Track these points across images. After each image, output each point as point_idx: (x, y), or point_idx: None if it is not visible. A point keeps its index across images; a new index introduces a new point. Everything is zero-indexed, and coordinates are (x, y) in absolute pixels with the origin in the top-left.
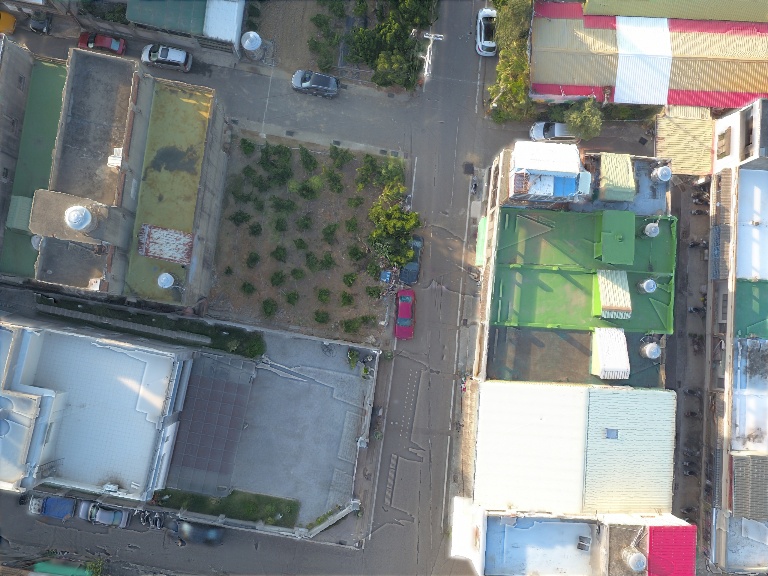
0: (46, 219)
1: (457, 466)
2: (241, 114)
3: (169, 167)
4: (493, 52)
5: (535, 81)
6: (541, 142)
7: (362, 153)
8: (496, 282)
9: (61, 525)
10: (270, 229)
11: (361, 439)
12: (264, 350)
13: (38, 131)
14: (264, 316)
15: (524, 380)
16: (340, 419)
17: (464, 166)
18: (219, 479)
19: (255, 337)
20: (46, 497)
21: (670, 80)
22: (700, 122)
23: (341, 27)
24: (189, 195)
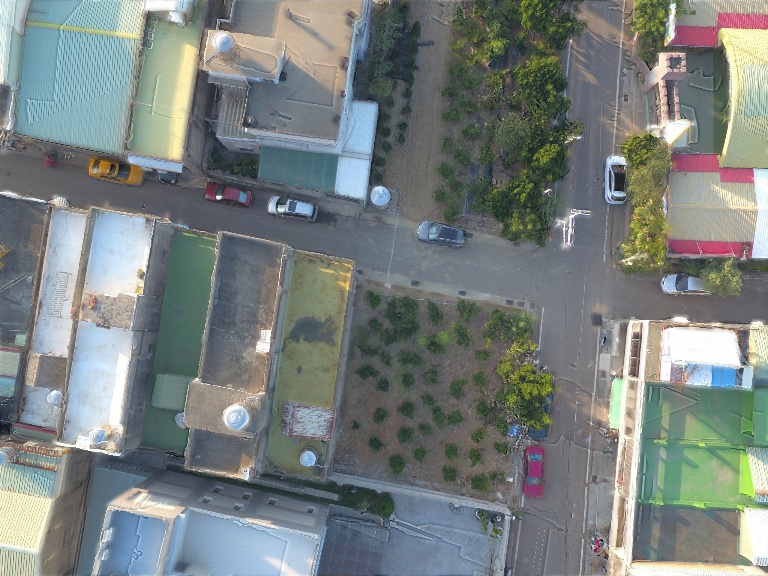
0: (200, 412)
1: None
2: (366, 264)
3: (308, 338)
4: (623, 201)
5: (670, 237)
6: (697, 328)
7: (488, 303)
8: (640, 458)
9: None
10: (396, 382)
11: None
12: (393, 510)
13: (178, 302)
14: (389, 471)
15: (669, 560)
16: None
17: (592, 317)
18: None
19: (382, 495)
20: None
21: None
22: None
23: (466, 174)
24: (327, 366)
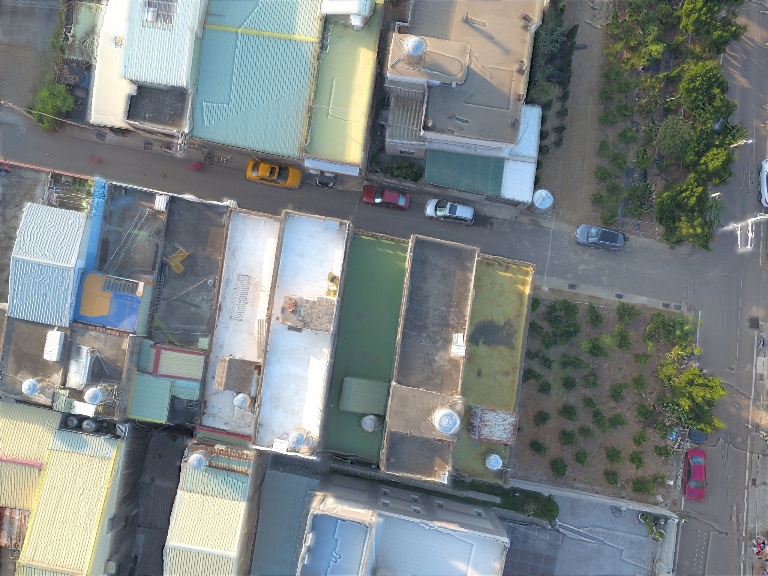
0: (403, 415)
1: None
2: None
3: (487, 341)
4: None
5: None
6: None
7: (645, 307)
8: None
9: None
10: (554, 385)
11: None
12: (558, 513)
13: (358, 305)
14: (549, 474)
15: None
16: None
17: (749, 320)
18: None
19: (544, 497)
20: None
21: None
22: None
23: (621, 177)
24: (507, 370)
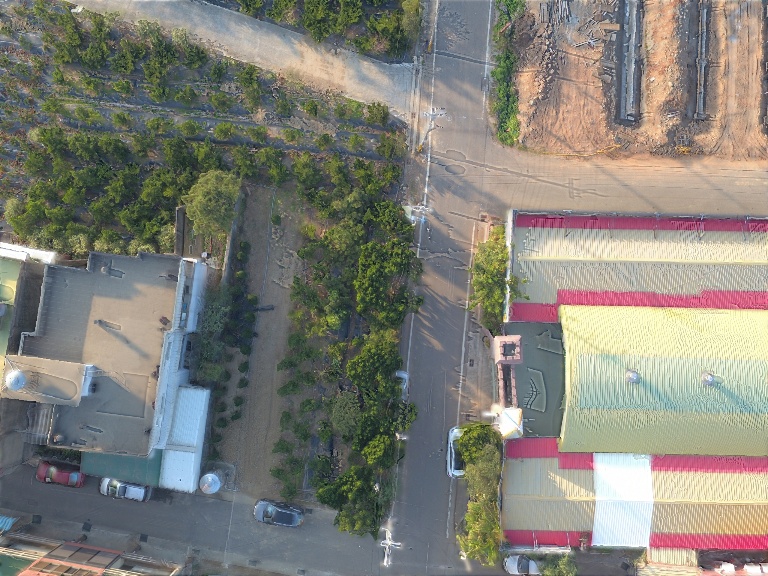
0: None
1: None
2: (202, 543)
3: None
4: None
5: (506, 527)
6: None
7: None
8: None
9: None
10: None
11: None
12: None
13: None
14: None
15: None
16: None
17: None
18: None
19: None
20: None
21: (652, 523)
22: (684, 575)
23: (306, 446)
24: None
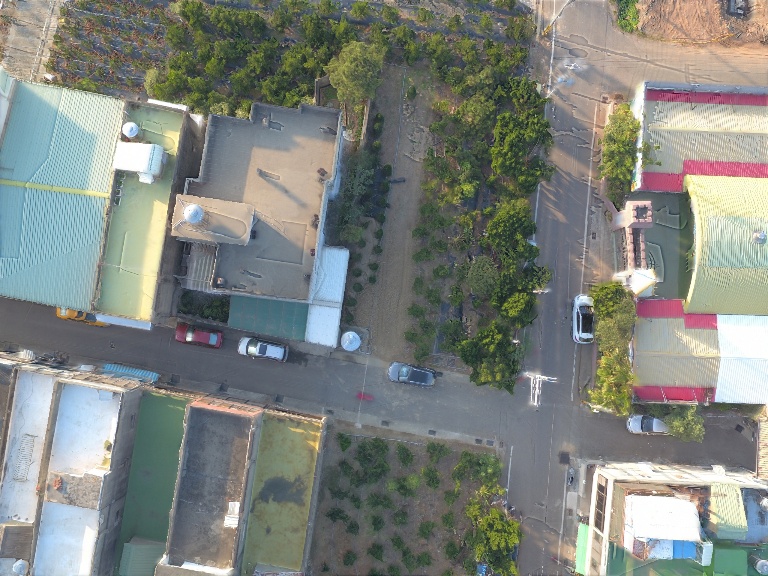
0: None
1: None
2: (337, 404)
3: (277, 498)
4: (590, 342)
5: (636, 383)
6: (659, 501)
7: (457, 443)
8: None
9: None
10: (366, 523)
11: None
12: None
13: (147, 463)
14: None
15: None
16: None
17: (560, 456)
18: None
19: None
20: None
21: None
22: None
23: (436, 313)
24: (297, 527)
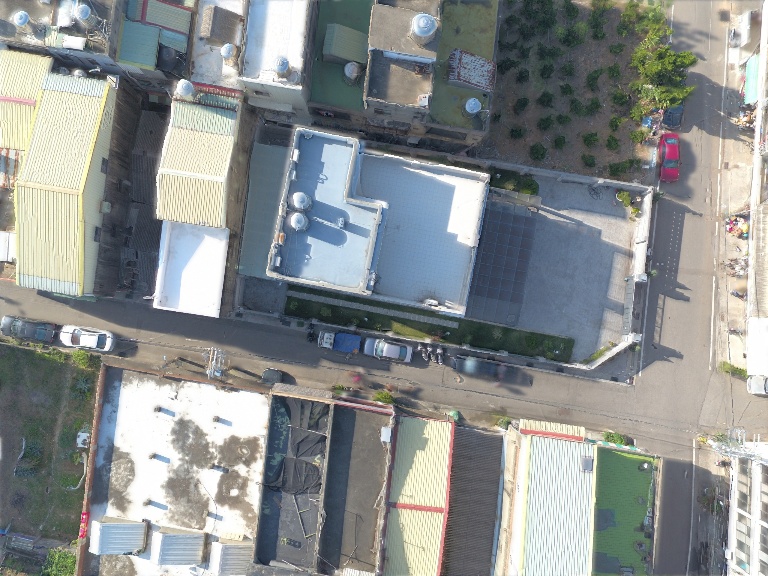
0: (384, 33)
1: (723, 305)
2: None
3: (465, 1)
4: None
5: None
6: None
7: (619, 2)
8: None
9: (345, 363)
10: (533, 77)
11: (639, 273)
12: (538, 190)
13: None
14: (530, 162)
15: None
16: (608, 260)
17: (720, 13)
18: (510, 308)
19: (525, 180)
20: (335, 333)
21: None
22: None
23: None
24: (485, 27)
